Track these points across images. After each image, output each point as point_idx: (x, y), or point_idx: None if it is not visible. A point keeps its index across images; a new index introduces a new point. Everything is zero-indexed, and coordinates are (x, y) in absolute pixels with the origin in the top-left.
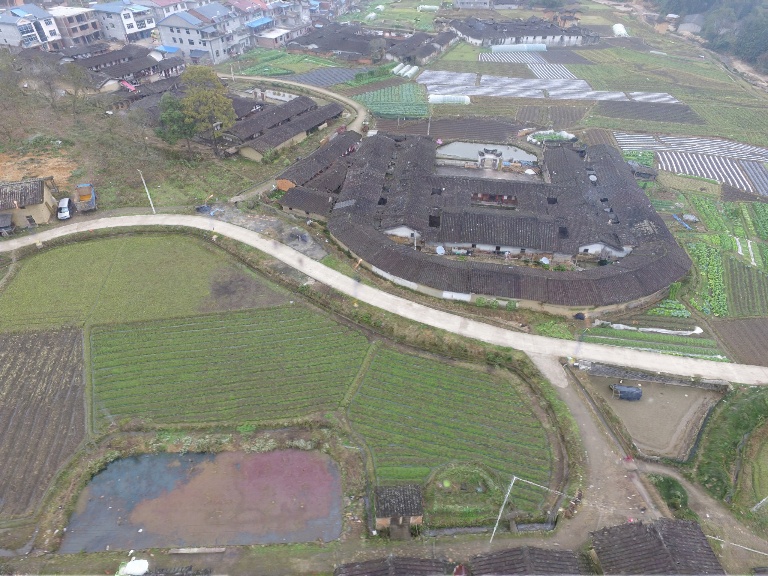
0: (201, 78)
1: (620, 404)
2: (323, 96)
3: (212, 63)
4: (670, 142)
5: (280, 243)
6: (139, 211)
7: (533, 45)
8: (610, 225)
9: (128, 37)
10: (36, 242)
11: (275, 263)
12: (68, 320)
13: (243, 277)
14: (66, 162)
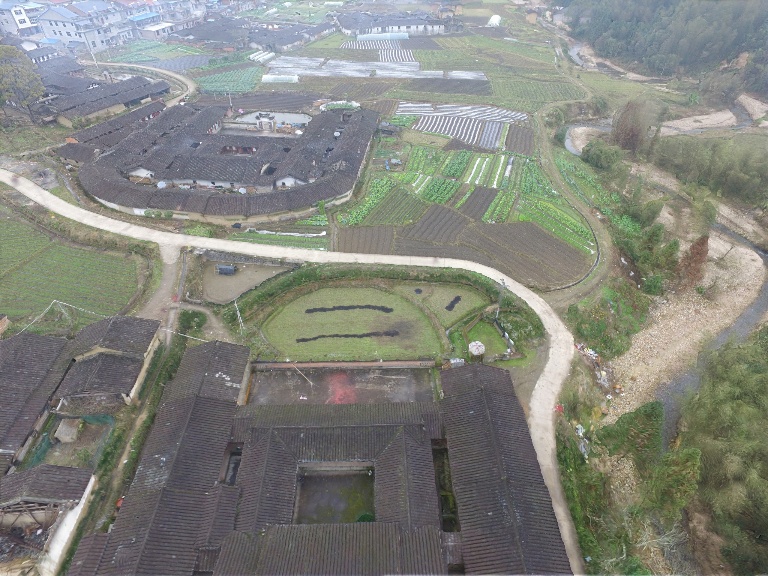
0: (2, 55)
1: (218, 277)
2: (167, 78)
3: (89, 53)
4: (443, 109)
5: (26, 179)
6: None
7: (396, 34)
8: (313, 165)
9: (21, 31)
10: None
11: (12, 192)
12: None
13: None
14: None
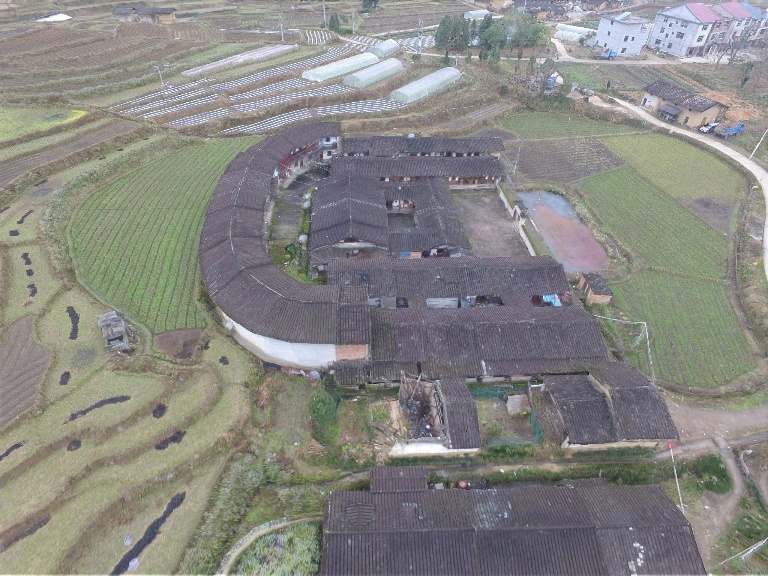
0: None
1: None
2: None
3: None
4: None
5: None
6: (745, 154)
7: None
8: None
9: None
10: (672, 130)
11: (759, 218)
12: (628, 158)
13: (728, 209)
14: (759, 114)
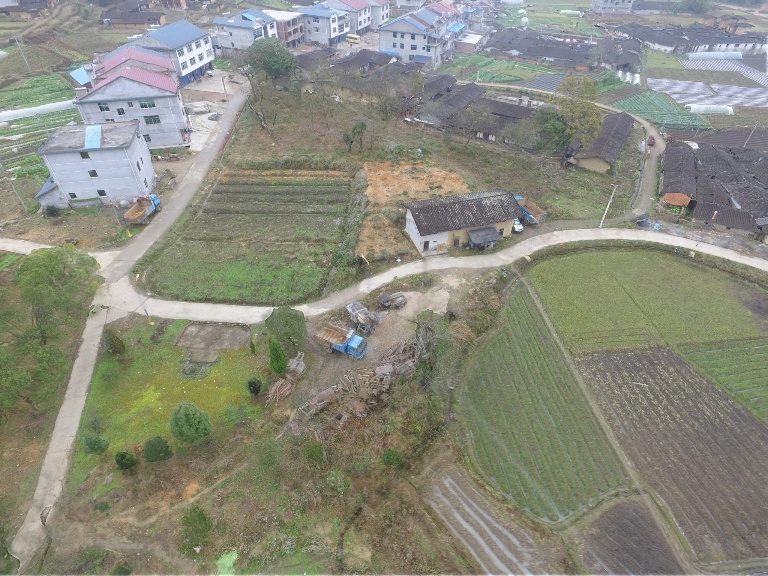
0: (588, 89)
1: None
2: None
3: (432, 68)
4: None
5: None
6: (576, 224)
7: (729, 53)
8: None
9: (331, 41)
10: (523, 256)
11: None
12: (646, 338)
13: (764, 296)
14: (447, 172)
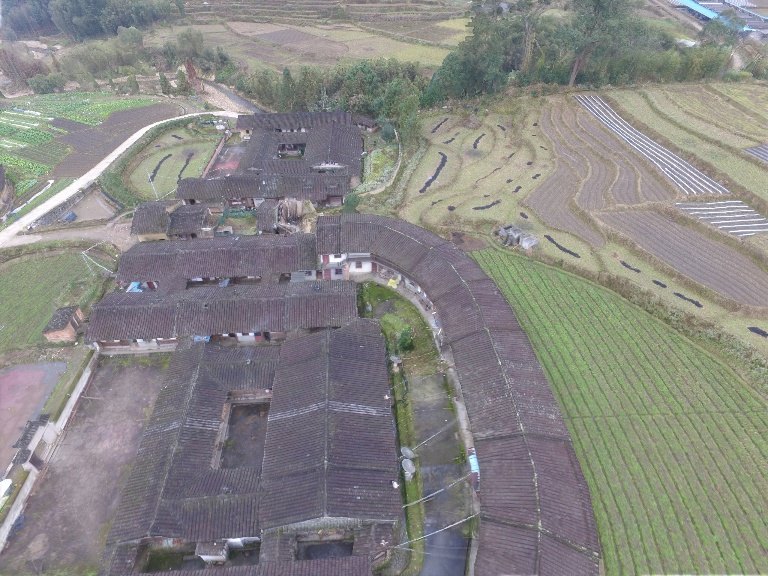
0: None
1: None
2: None
3: None
4: None
5: None
6: None
7: None
8: None
9: None
10: None
11: None
12: None
13: None
14: None
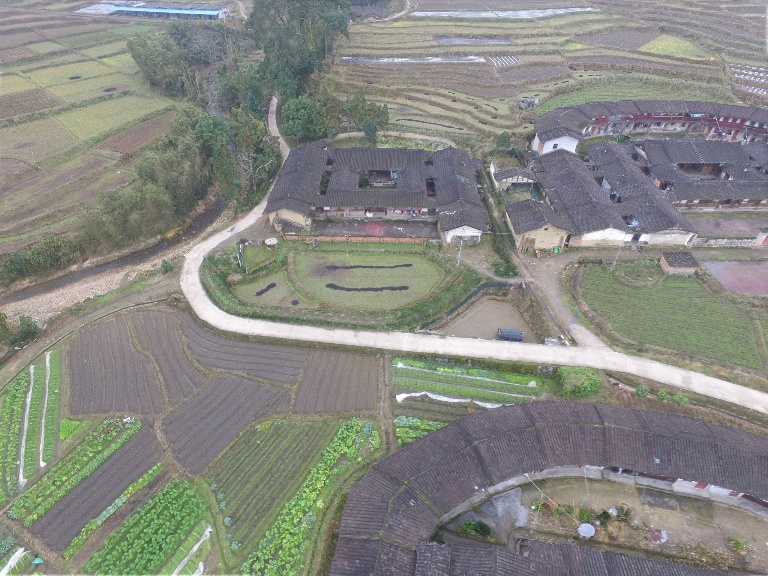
0: None
1: None
2: None
3: None
4: None
5: None
6: None
7: None
8: None
9: None
10: None
11: None
12: None
13: None
14: None
